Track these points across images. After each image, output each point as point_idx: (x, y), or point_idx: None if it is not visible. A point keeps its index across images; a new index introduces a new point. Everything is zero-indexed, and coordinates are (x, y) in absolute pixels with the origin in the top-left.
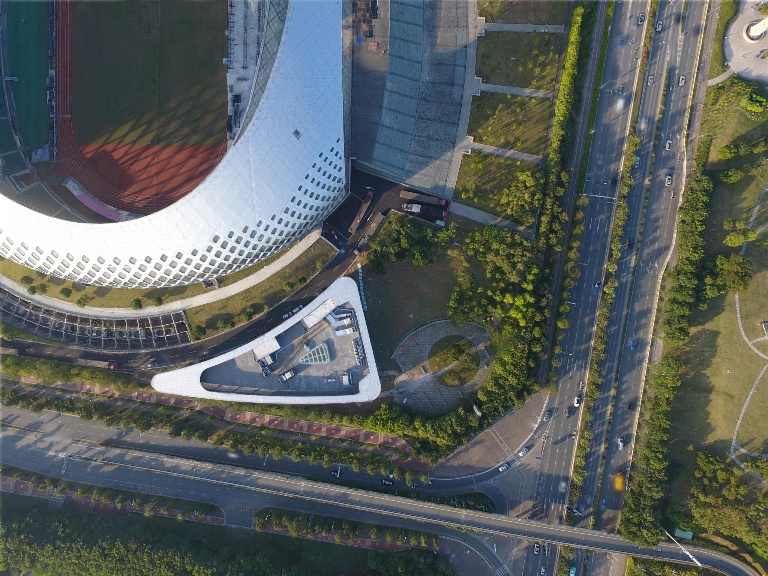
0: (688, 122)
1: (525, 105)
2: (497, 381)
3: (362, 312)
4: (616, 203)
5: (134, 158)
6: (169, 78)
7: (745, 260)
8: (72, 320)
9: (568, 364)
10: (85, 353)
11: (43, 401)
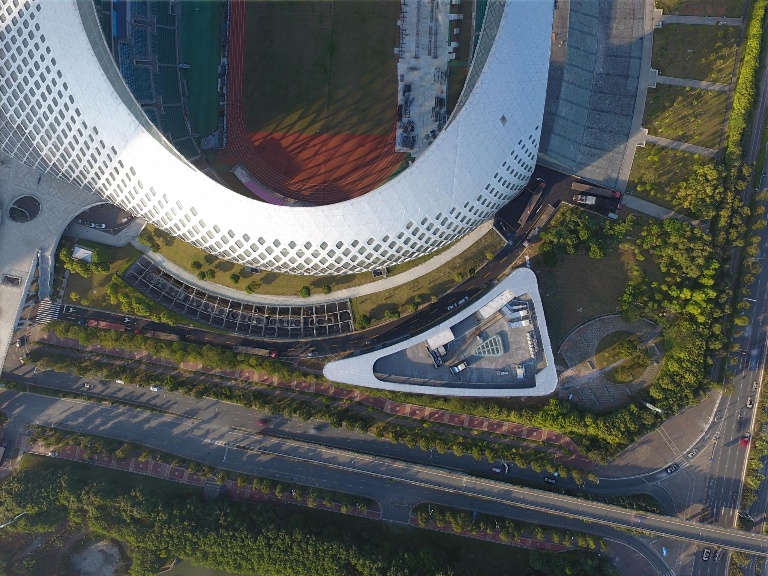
0: None
1: (701, 98)
2: (673, 378)
3: (541, 304)
4: None
5: (302, 146)
6: (340, 67)
7: None
8: (233, 307)
9: (741, 363)
10: (245, 340)
11: (201, 388)
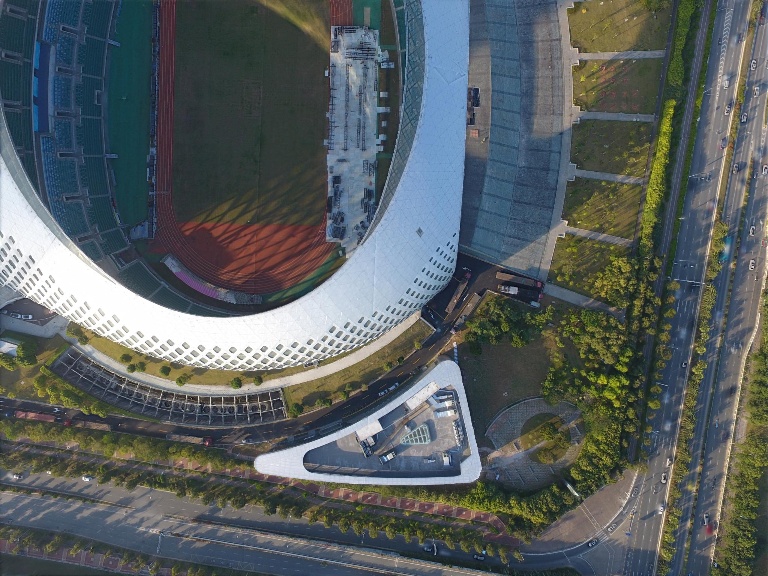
0: None
1: (617, 191)
2: (591, 460)
3: (465, 395)
4: (703, 286)
5: (233, 236)
6: (270, 158)
7: None
8: (166, 395)
9: (656, 441)
10: (178, 428)
11: (135, 477)
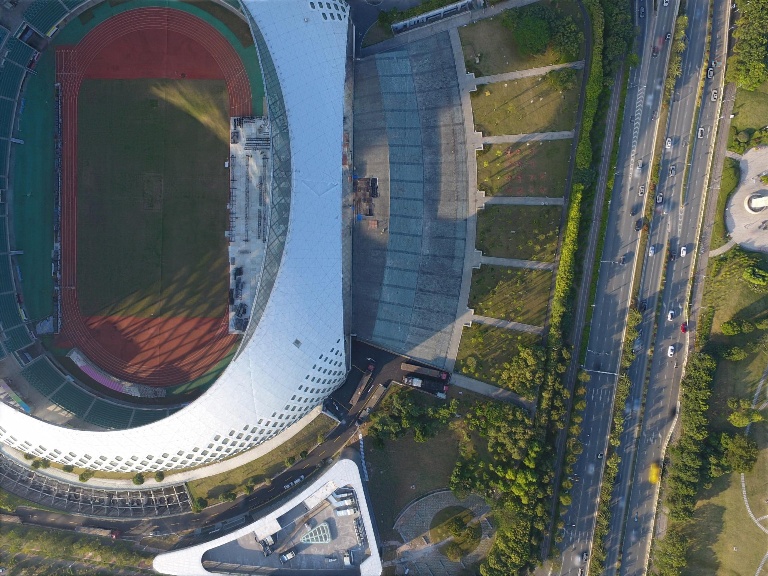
0: (690, 293)
1: (526, 277)
2: (499, 558)
3: (363, 495)
4: (618, 374)
5: (137, 329)
6: (172, 251)
7: (750, 444)
8: (75, 487)
9: (571, 535)
10: (88, 520)
11: (46, 568)
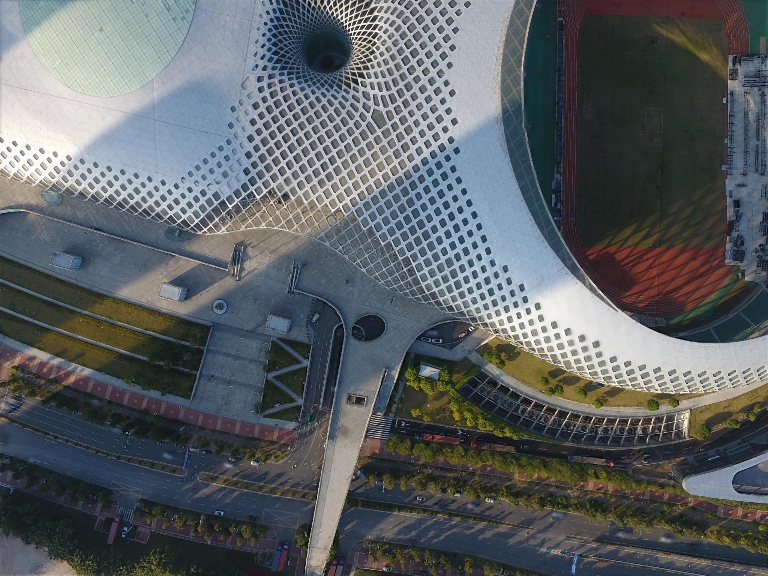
0: None
1: None
2: None
3: None
4: None
5: (636, 260)
6: (671, 183)
7: None
8: None
9: None
10: (578, 450)
11: (536, 498)
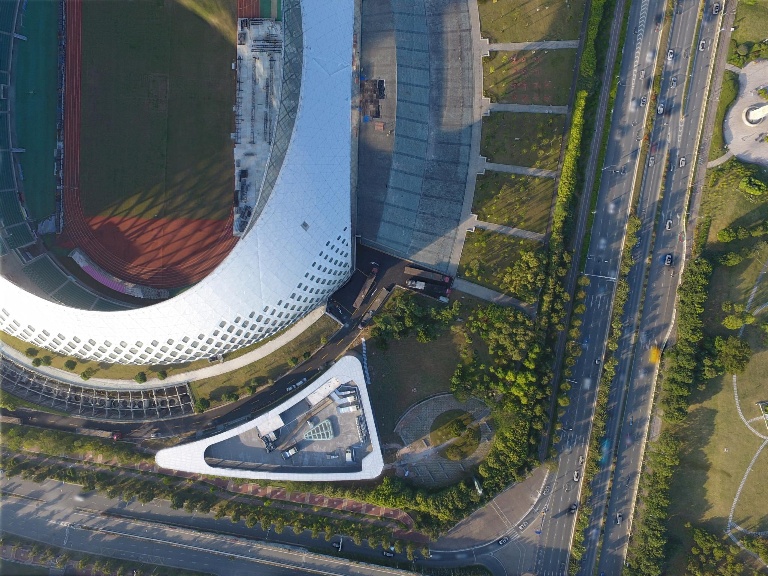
0: (688, 203)
1: (529, 184)
2: (498, 458)
3: (366, 391)
4: (617, 281)
5: (140, 230)
6: (177, 152)
7: (743, 344)
8: (76, 389)
9: (568, 439)
10: (88, 422)
11: (45, 470)
